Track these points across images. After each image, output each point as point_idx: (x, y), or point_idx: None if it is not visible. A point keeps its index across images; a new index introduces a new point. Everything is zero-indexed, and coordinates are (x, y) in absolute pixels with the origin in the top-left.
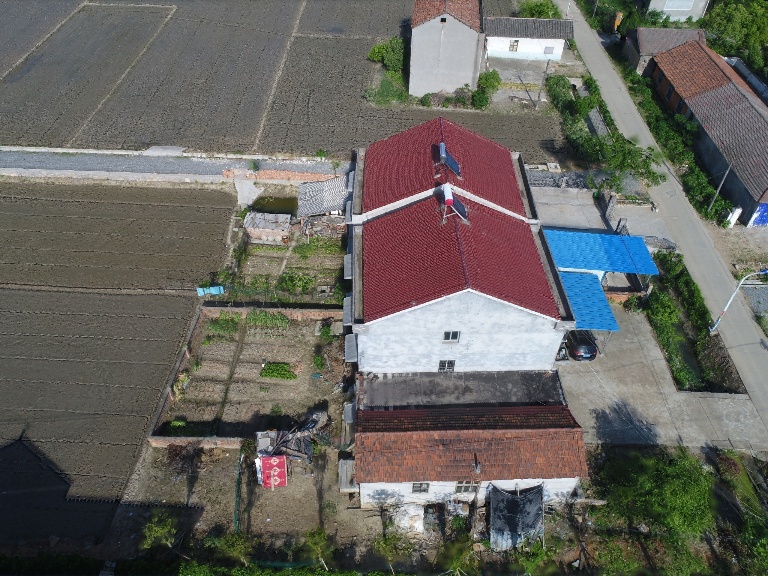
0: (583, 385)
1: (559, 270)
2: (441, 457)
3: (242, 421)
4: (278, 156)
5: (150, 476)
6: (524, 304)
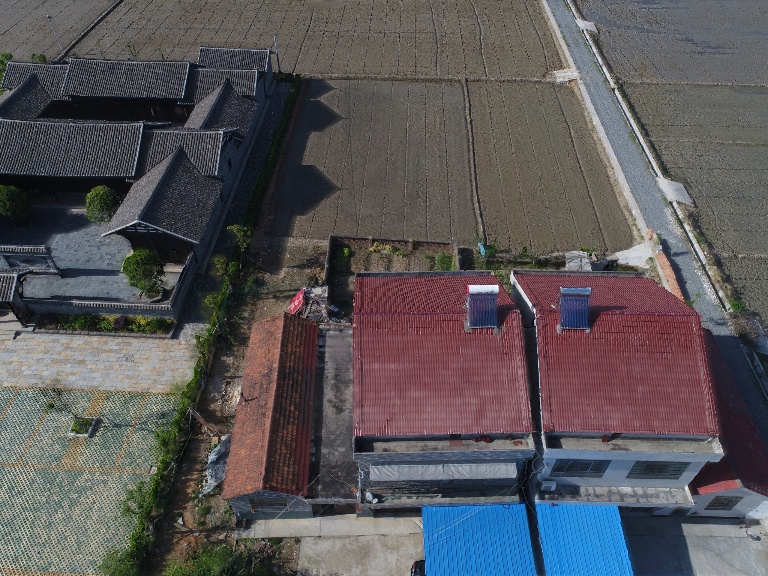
0: (378, 575)
1: (540, 543)
2: (259, 373)
3: (350, 287)
4: (710, 270)
5: (308, 247)
6: (357, 383)
